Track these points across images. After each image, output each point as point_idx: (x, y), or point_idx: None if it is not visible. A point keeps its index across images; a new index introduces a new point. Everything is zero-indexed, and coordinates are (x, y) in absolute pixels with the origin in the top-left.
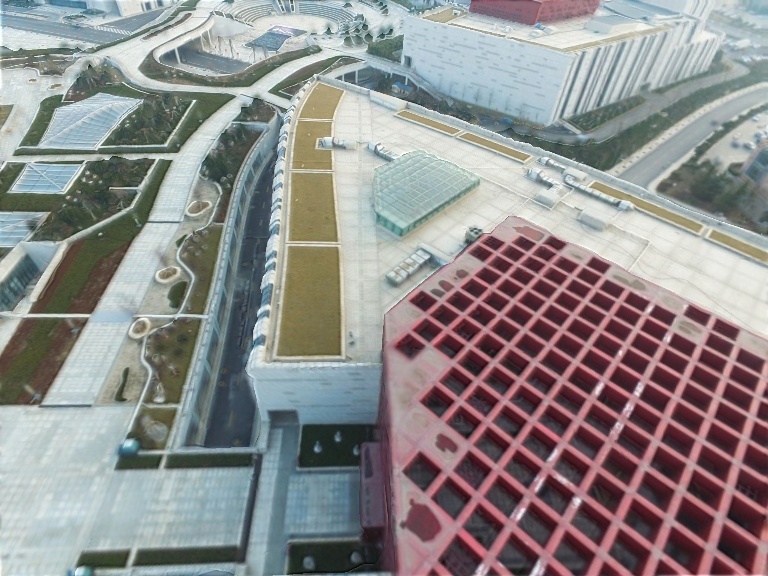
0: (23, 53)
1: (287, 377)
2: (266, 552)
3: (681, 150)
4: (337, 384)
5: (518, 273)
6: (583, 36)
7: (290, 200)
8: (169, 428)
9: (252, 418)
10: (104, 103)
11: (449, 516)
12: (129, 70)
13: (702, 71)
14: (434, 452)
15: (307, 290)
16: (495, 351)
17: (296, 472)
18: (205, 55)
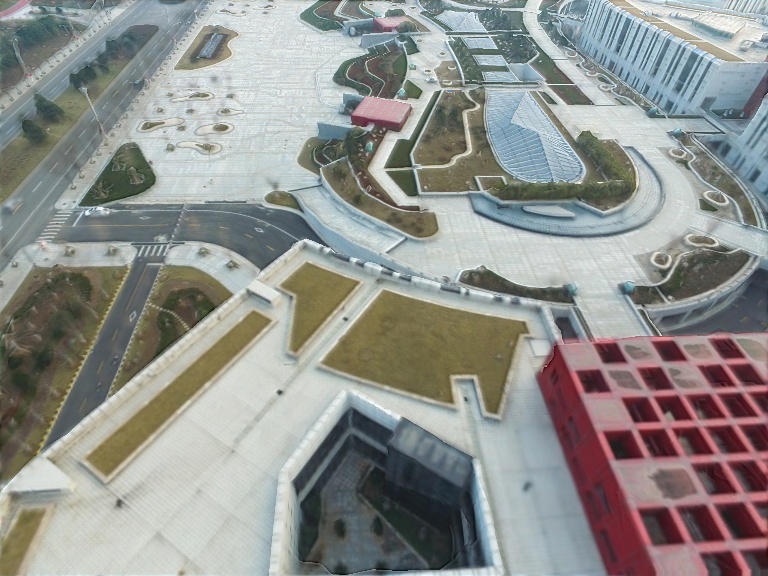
0: None
1: (732, 70)
2: None
3: None
4: (747, 76)
5: None
6: None
7: None
8: None
9: None
10: None
11: None
12: None
13: None
14: None
15: None
16: None
17: (722, 120)
18: None
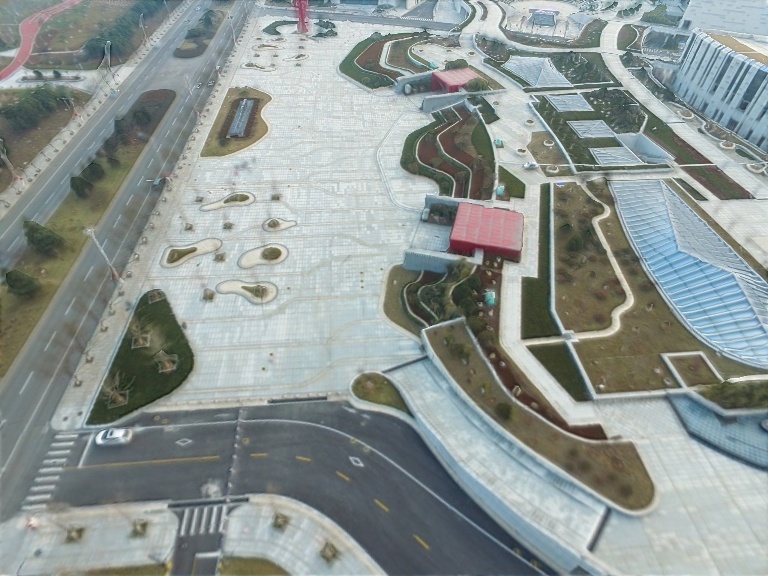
0: (391, 37)
1: None
2: None
3: None
4: None
5: None
6: None
7: None
8: None
9: None
10: (530, 60)
11: None
12: (504, 41)
13: None
14: None
15: None
16: None
17: None
18: None
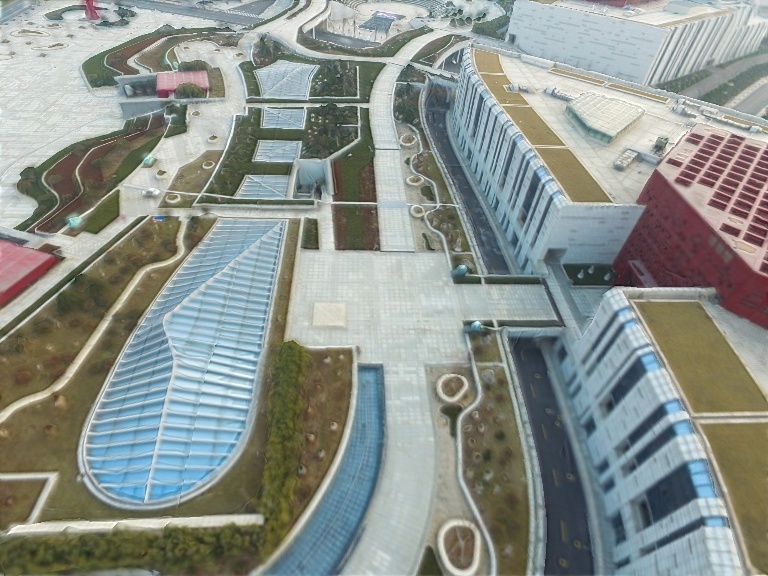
0: (185, 31)
1: (581, 215)
2: (577, 324)
3: (752, 111)
4: (609, 223)
5: (724, 151)
6: (667, 16)
7: (514, 122)
8: (474, 264)
9: (508, 271)
10: (290, 67)
11: (757, 246)
12: (290, 43)
13: (753, 51)
14: (731, 223)
15: (566, 171)
16: (735, 186)
17: (572, 288)
18: (331, 34)
